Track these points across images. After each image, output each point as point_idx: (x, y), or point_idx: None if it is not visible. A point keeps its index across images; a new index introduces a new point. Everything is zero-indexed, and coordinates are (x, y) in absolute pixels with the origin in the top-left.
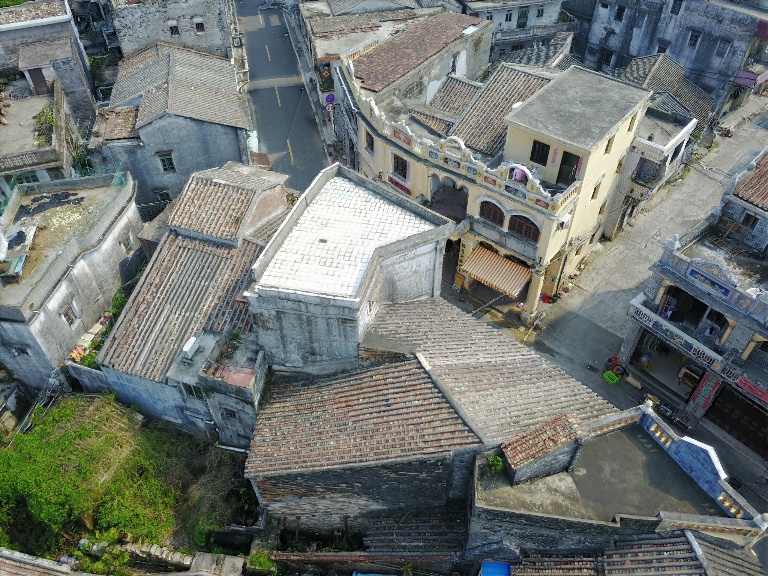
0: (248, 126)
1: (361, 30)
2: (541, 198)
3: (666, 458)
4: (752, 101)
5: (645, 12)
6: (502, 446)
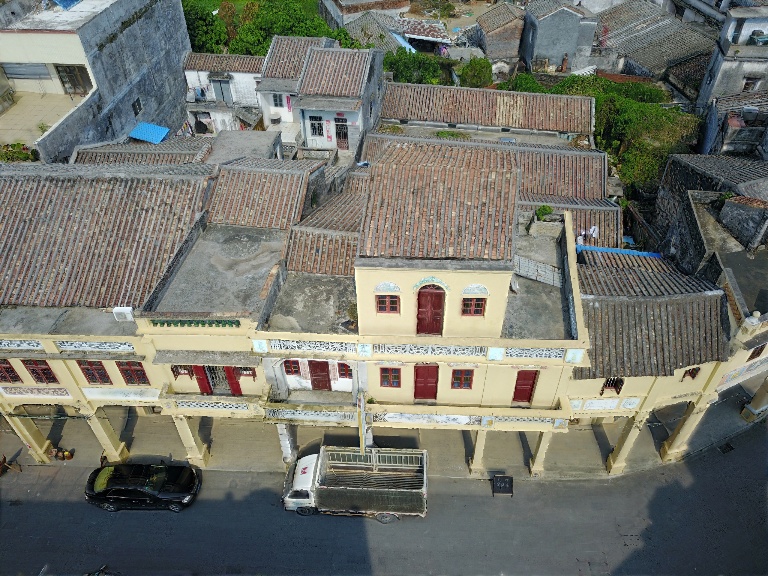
0: None
1: None
2: None
3: None
4: None
5: None
6: (742, 195)
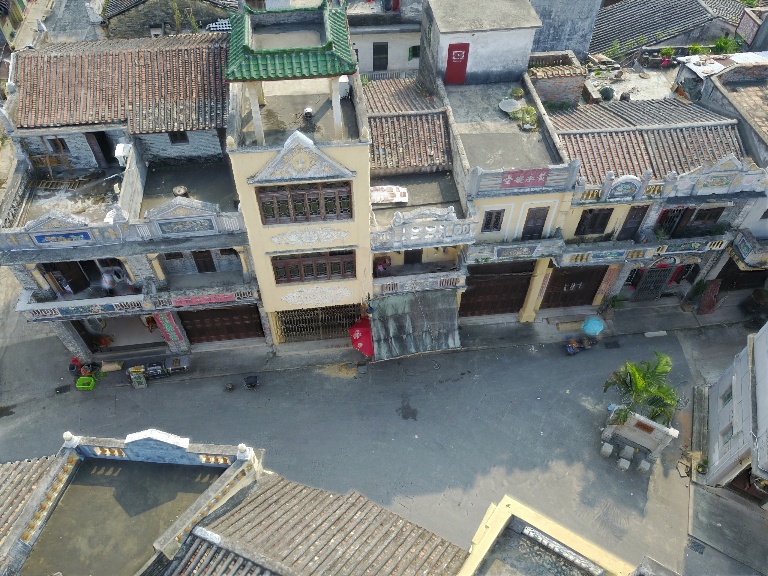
0: None
1: None
2: None
3: (135, 467)
4: (31, 9)
5: None
6: None
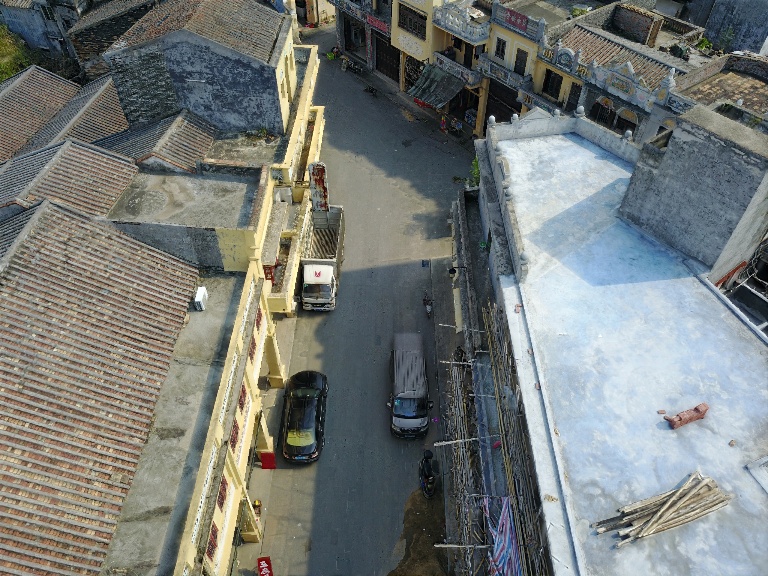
0: None
1: None
2: None
3: None
4: None
5: None
6: None
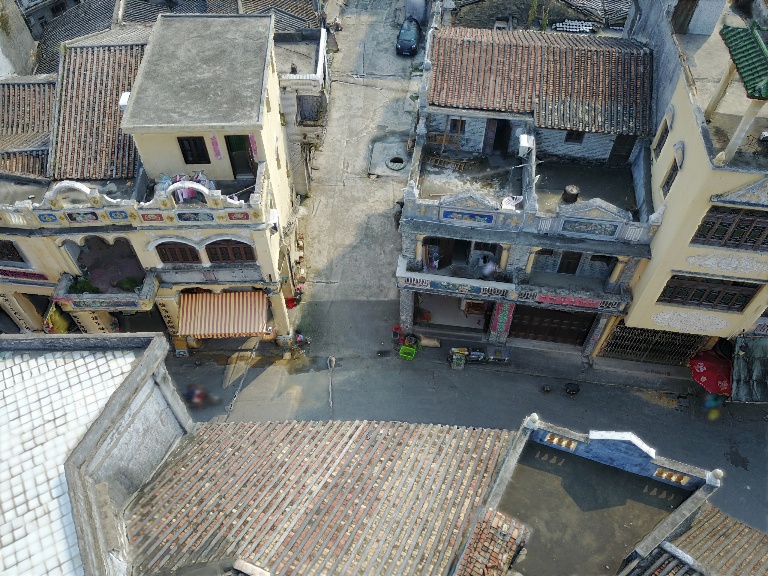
0: None
1: None
2: (234, 210)
3: (578, 462)
4: None
5: None
6: None
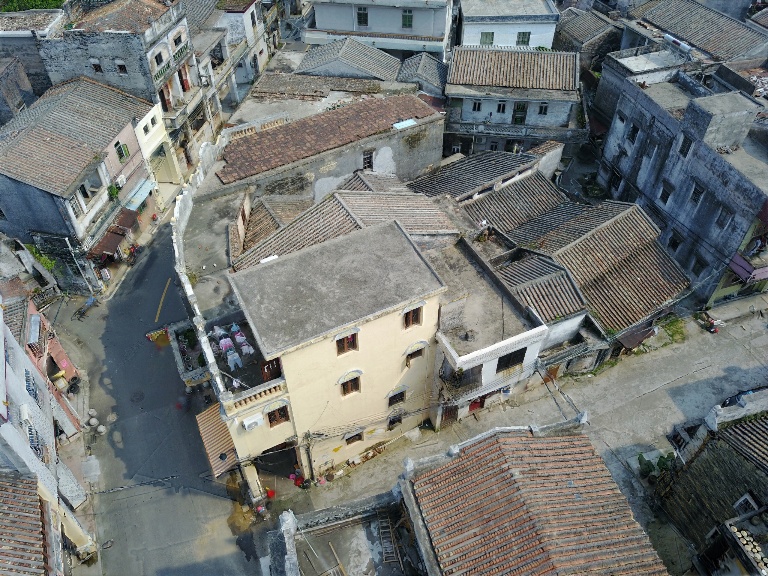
0: (68, 193)
1: (302, 97)
2: None
3: None
4: None
5: (655, 141)
6: None
